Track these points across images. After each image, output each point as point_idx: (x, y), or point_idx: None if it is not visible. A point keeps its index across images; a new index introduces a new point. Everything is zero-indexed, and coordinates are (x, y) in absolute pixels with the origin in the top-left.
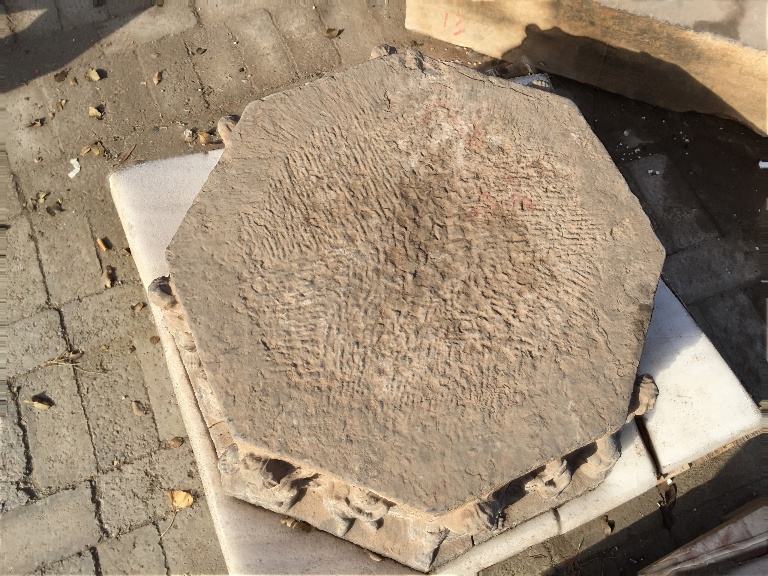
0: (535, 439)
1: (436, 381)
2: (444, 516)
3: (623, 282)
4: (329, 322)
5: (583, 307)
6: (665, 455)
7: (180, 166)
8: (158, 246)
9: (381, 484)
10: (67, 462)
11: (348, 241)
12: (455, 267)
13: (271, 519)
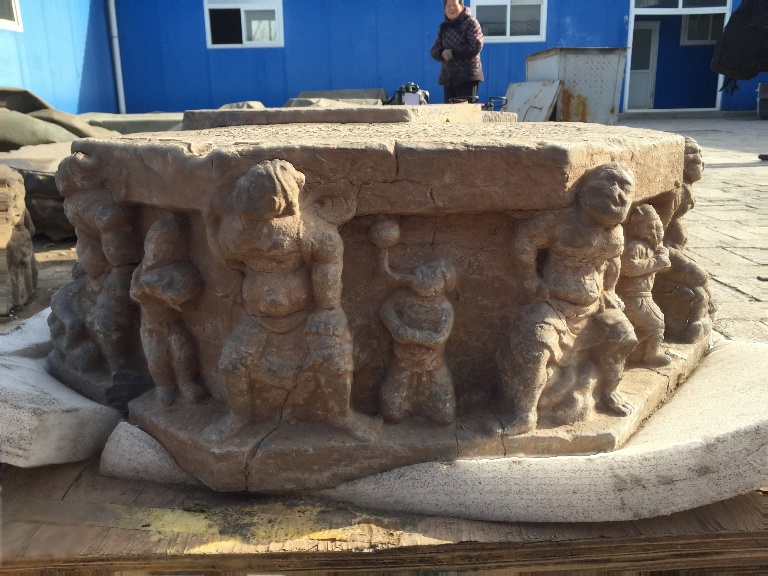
0: None
1: None
2: None
3: None
4: None
5: None
6: None
7: (762, 413)
8: (761, 359)
9: None
10: None
11: None
12: None
13: None
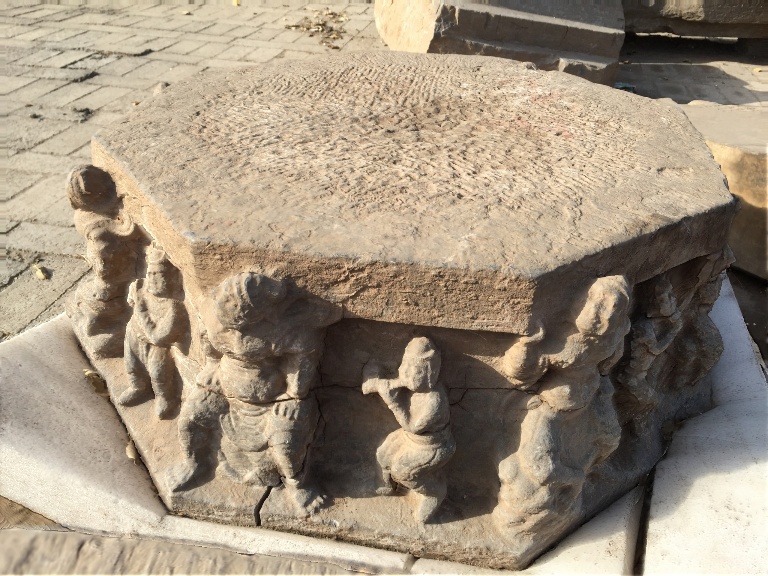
0: (388, 239)
1: (324, 173)
2: (211, 299)
3: (645, 196)
4: (270, 122)
5: (568, 192)
6: (656, 570)
7: None
8: None
9: (168, 199)
10: (8, 315)
11: (350, 104)
12: (439, 140)
13: (79, 363)
